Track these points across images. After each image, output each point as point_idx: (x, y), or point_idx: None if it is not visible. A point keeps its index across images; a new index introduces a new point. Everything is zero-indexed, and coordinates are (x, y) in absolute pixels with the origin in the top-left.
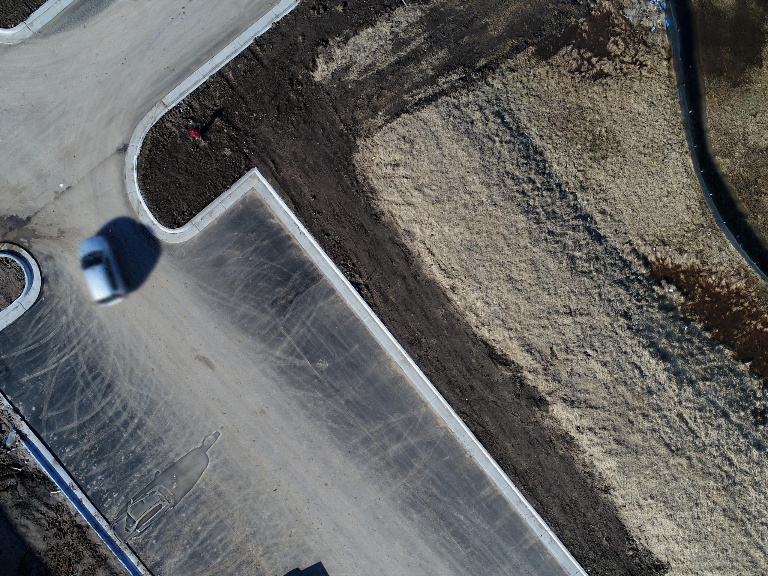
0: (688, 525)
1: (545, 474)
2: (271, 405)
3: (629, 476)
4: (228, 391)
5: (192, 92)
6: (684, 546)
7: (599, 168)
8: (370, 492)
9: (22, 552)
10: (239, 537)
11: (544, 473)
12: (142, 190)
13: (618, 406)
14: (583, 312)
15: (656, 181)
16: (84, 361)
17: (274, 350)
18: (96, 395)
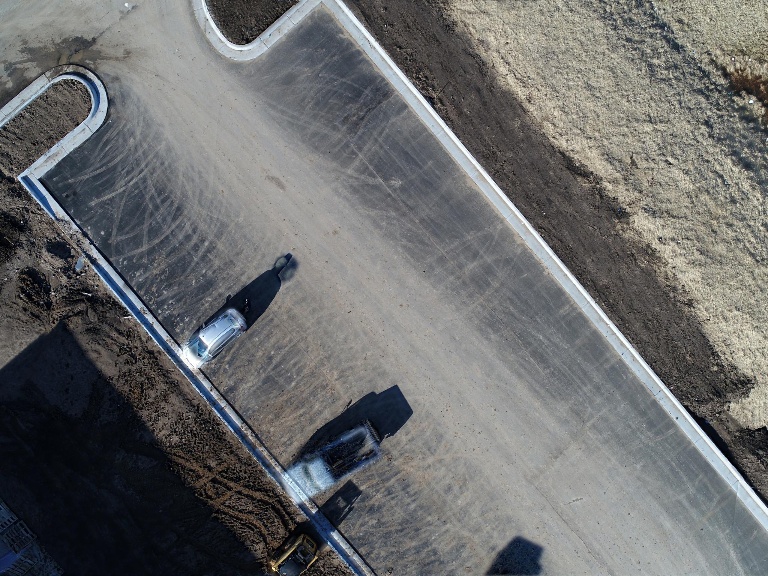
0: None
1: (626, 289)
2: (344, 225)
3: (713, 288)
4: (299, 211)
5: None
6: None
7: None
8: (446, 312)
9: (94, 377)
10: (313, 361)
11: (625, 288)
12: (209, 6)
13: (701, 215)
14: (663, 119)
15: None
16: (152, 184)
17: (346, 168)
18: (165, 218)
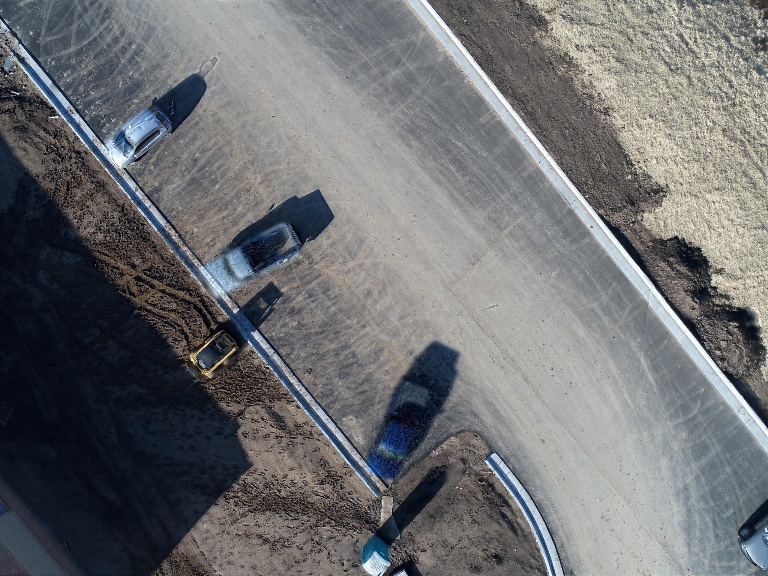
0: (687, 145)
1: (544, 97)
2: (269, 30)
3: (628, 95)
4: (226, 16)
5: None
6: (683, 167)
7: None
8: (368, 118)
9: (20, 174)
10: (237, 164)
11: (543, 96)
12: None
13: (617, 23)
14: None
15: None
16: None
17: None
18: (93, 20)
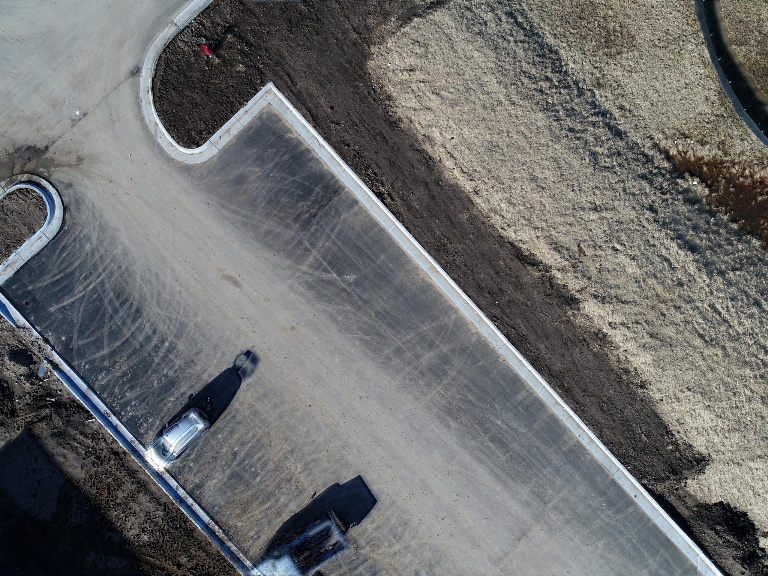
0: (727, 415)
1: (580, 373)
2: (301, 321)
3: (664, 369)
4: (257, 309)
5: (203, 10)
6: (724, 436)
7: (615, 64)
8: (405, 402)
9: (60, 482)
10: (276, 455)
11: (579, 372)
12: (159, 112)
13: (649, 299)
14: (609, 207)
15: (673, 73)
16: (111, 288)
17: (300, 265)
18: (125, 321)
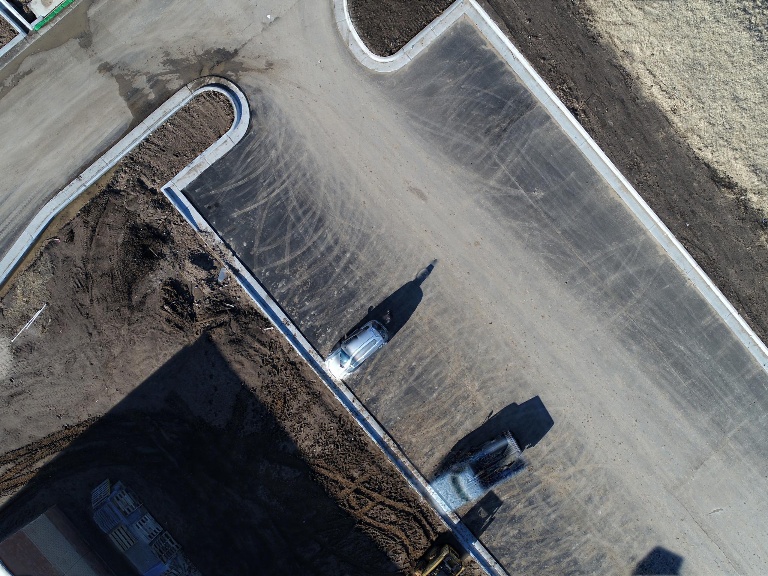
0: None
1: None
2: (486, 236)
3: None
4: (441, 223)
5: None
6: None
7: None
8: (588, 323)
9: (237, 389)
10: (454, 372)
11: None
12: (352, 18)
13: None
14: None
15: None
16: (294, 195)
17: (488, 180)
18: (307, 230)
